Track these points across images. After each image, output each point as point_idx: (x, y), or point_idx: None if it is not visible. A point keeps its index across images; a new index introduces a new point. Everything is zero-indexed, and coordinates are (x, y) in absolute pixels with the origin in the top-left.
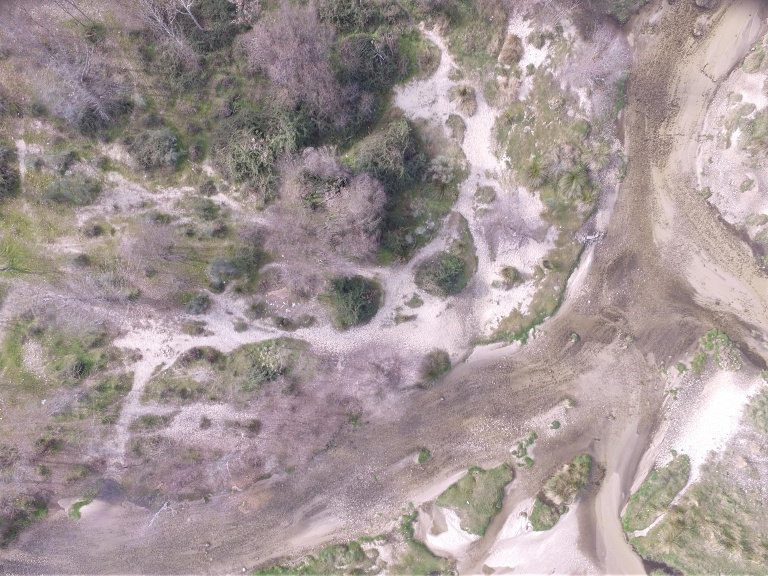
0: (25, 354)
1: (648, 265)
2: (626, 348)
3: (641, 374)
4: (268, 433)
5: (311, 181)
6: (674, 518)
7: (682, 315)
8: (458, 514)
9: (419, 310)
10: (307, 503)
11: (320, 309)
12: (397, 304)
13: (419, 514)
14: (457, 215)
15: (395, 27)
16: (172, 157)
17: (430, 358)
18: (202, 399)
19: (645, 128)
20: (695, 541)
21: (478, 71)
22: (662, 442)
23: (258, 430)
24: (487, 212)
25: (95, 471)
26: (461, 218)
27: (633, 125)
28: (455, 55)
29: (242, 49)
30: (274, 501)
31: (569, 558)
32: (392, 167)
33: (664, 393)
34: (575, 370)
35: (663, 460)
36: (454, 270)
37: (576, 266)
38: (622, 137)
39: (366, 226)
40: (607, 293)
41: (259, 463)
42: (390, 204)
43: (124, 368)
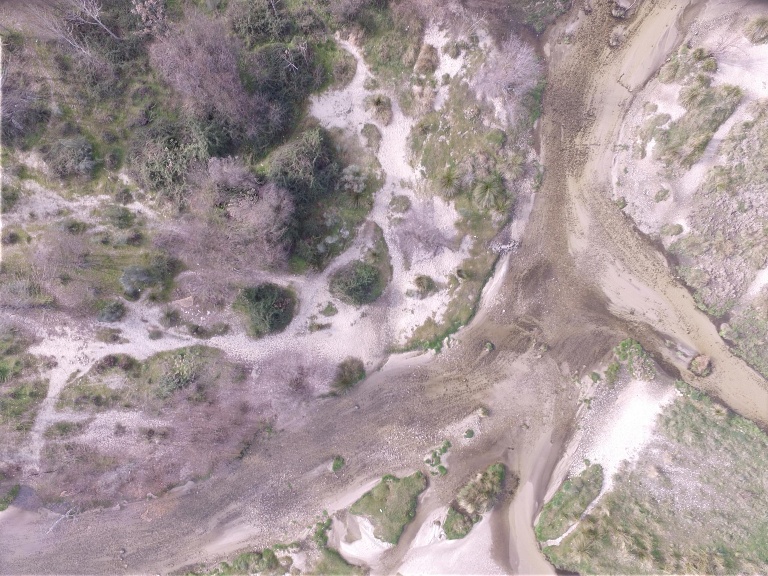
0: None
1: (563, 275)
2: (540, 357)
3: (555, 383)
4: (183, 440)
5: (225, 190)
6: (586, 527)
7: (596, 325)
8: (372, 522)
9: (334, 319)
10: (222, 510)
11: (235, 317)
12: (312, 312)
13: (333, 522)
14: (372, 224)
15: (310, 37)
16: (86, 166)
17: (344, 366)
18: (117, 406)
19: (561, 138)
20: (607, 551)
21: (393, 81)
22: (576, 451)
23: (173, 437)
24: (401, 221)
25: (10, 477)
26: (376, 227)
27: (549, 135)
28: (370, 65)
29: (157, 58)
30: (189, 508)
31: (482, 567)
32: (301, 177)
33: (578, 402)
34: (489, 379)
35: (576, 469)
36: (367, 279)
37: (491, 275)
38: (538, 147)
39: (269, 236)
40: (522, 302)
41: (174, 470)
42: (303, 213)
43: (39, 375)
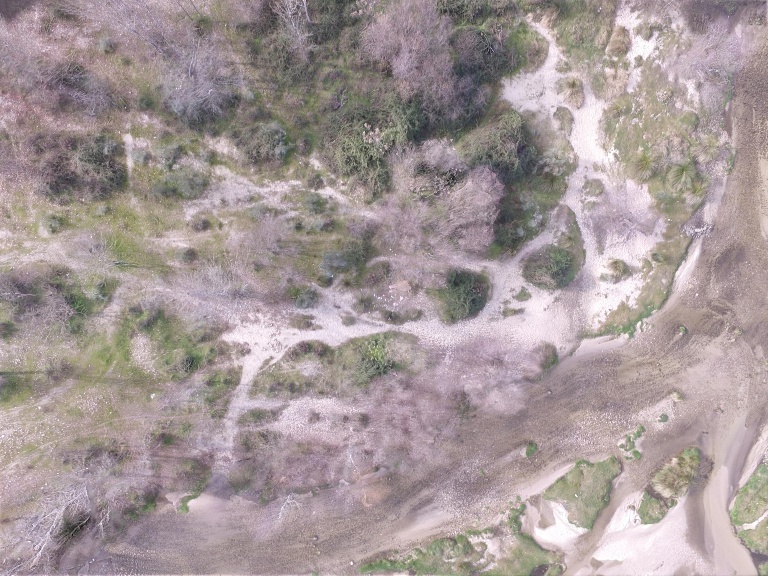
0: (134, 348)
1: (756, 258)
2: (734, 341)
3: (749, 367)
4: (376, 427)
5: (420, 174)
6: None
7: None
8: (566, 507)
9: (527, 303)
10: (414, 497)
11: (428, 303)
12: (505, 297)
13: (527, 507)
14: (565, 208)
15: (503, 19)
16: (282, 150)
17: (538, 351)
18: (310, 393)
19: (753, 120)
20: None
21: (586, 63)
22: None
23: (366, 424)
24: (595, 205)
25: (203, 465)
26: (569, 211)
27: (741, 117)
28: (563, 47)
29: (350, 42)
30: (381, 495)
31: (677, 551)
32: (507, 160)
33: None
34: (683, 363)
35: None
36: (564, 263)
37: (684, 259)
38: (730, 129)
39: (488, 219)
40: (715, 286)
41: (367, 457)
42: None
43: (232, 362)
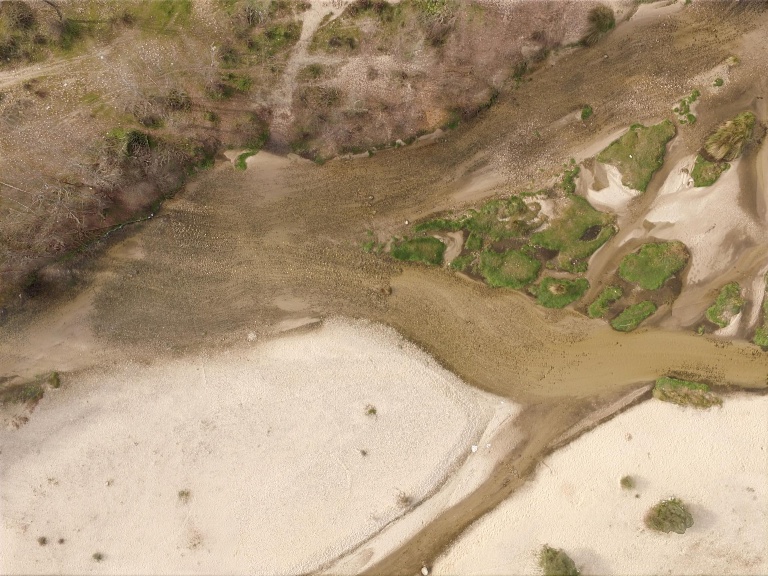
0: (196, 1)
1: None
2: None
3: None
4: (433, 86)
5: None
6: None
7: None
8: (620, 170)
9: None
10: (469, 159)
11: None
12: None
13: (581, 170)
14: None
15: None
16: None
17: (596, 12)
18: (369, 50)
19: None
20: None
21: None
22: None
23: (424, 82)
24: None
25: (262, 121)
26: None
27: None
28: None
29: None
30: (437, 156)
31: (729, 214)
32: None
33: None
34: (739, 29)
35: None
36: None
37: None
38: None
39: None
40: None
41: (424, 116)
42: None
43: (293, 17)
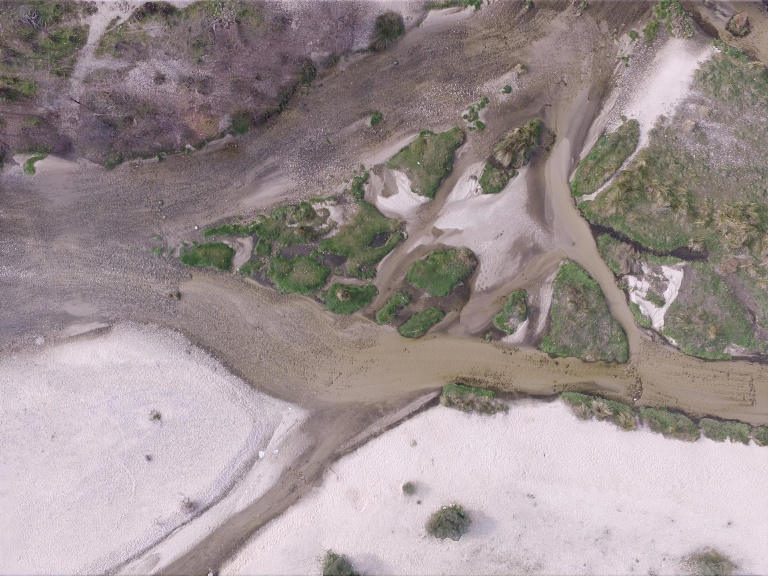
0: None
1: None
2: (580, 15)
3: (594, 41)
4: (222, 91)
5: None
6: (622, 180)
7: None
8: (409, 177)
9: None
10: (260, 164)
11: None
12: None
13: (370, 176)
14: None
15: None
16: None
17: (384, 18)
18: (157, 55)
19: None
20: (642, 205)
21: None
22: (613, 108)
23: (212, 87)
24: None
25: (50, 125)
26: None
27: None
28: None
29: None
30: (227, 162)
31: (517, 221)
32: None
33: (616, 60)
34: (528, 37)
35: (613, 126)
36: None
37: None
38: None
39: None
40: None
41: (213, 121)
42: None
43: (79, 21)
